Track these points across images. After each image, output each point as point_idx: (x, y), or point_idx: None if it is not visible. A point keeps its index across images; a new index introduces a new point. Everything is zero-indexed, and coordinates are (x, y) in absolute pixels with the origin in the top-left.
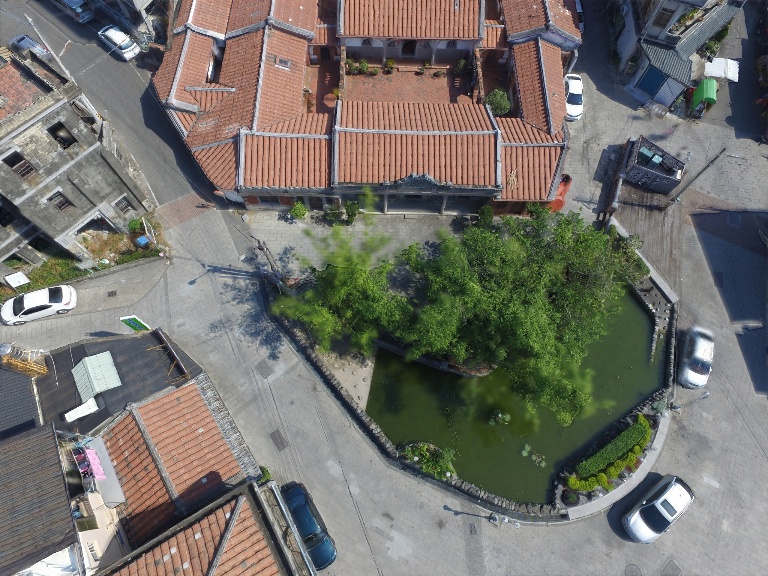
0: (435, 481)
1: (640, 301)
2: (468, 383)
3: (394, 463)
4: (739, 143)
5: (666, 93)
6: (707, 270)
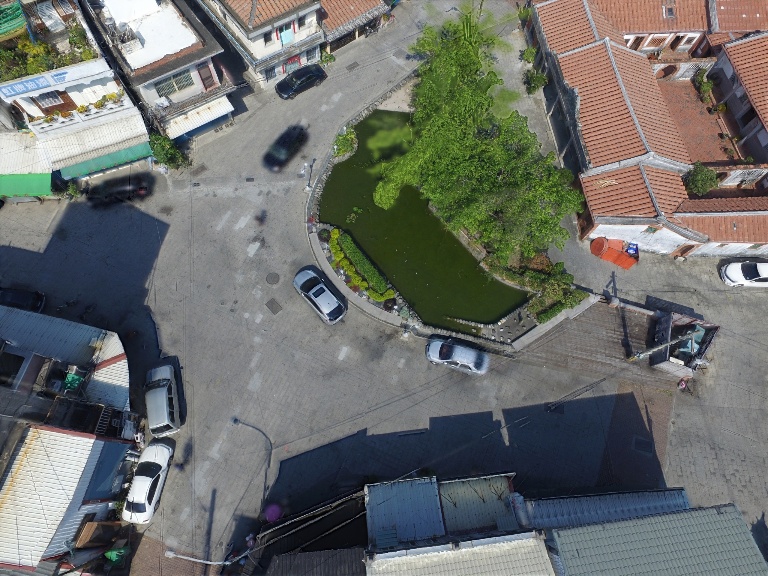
0: None
1: None
2: None
3: None
4: None
5: None
6: None
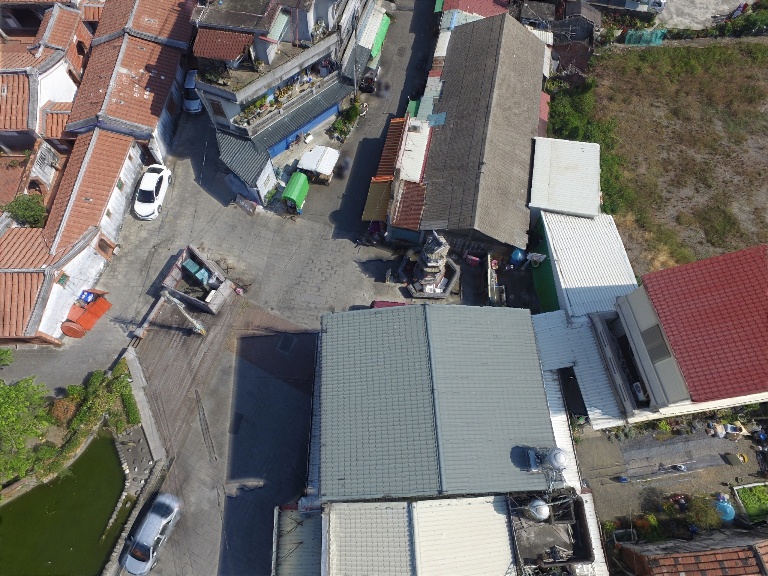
0: None
1: None
2: None
3: None
4: (333, 245)
5: (251, 188)
6: (228, 411)
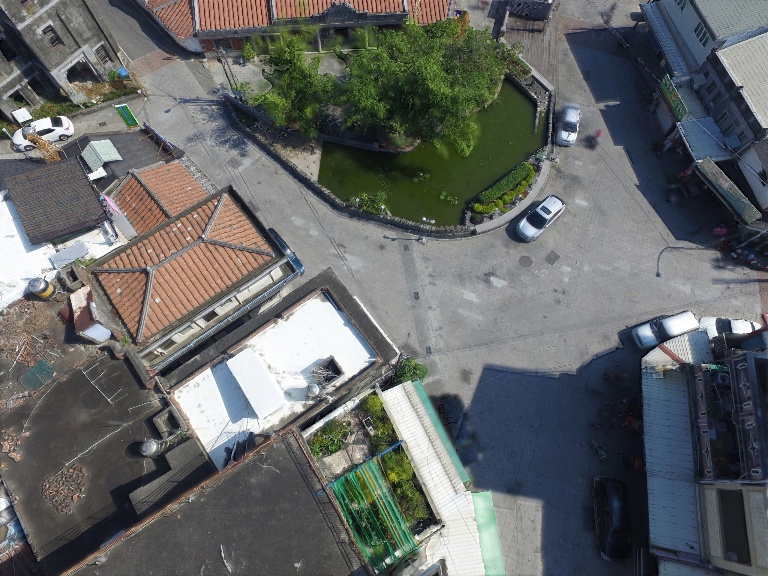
0: (375, 222)
1: (525, 93)
2: (396, 158)
3: (343, 214)
4: None
5: None
6: (578, 70)
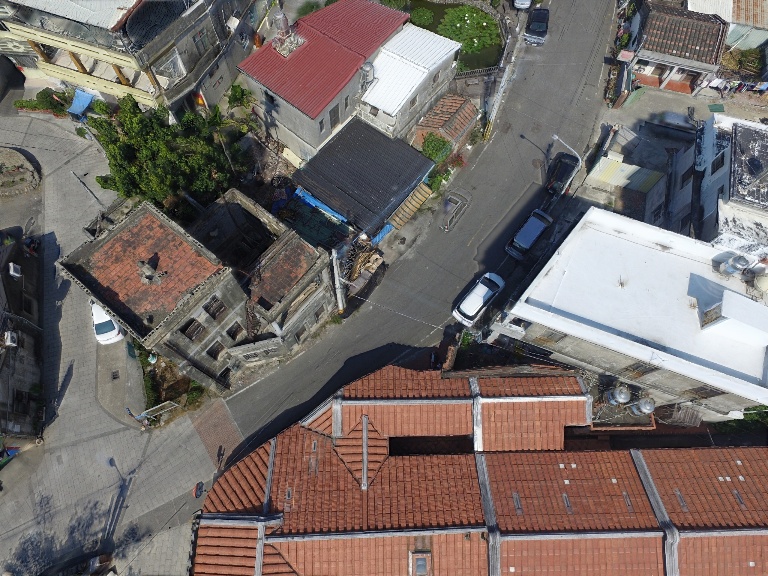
0: None
1: None
2: None
3: None
4: None
5: None
6: None
